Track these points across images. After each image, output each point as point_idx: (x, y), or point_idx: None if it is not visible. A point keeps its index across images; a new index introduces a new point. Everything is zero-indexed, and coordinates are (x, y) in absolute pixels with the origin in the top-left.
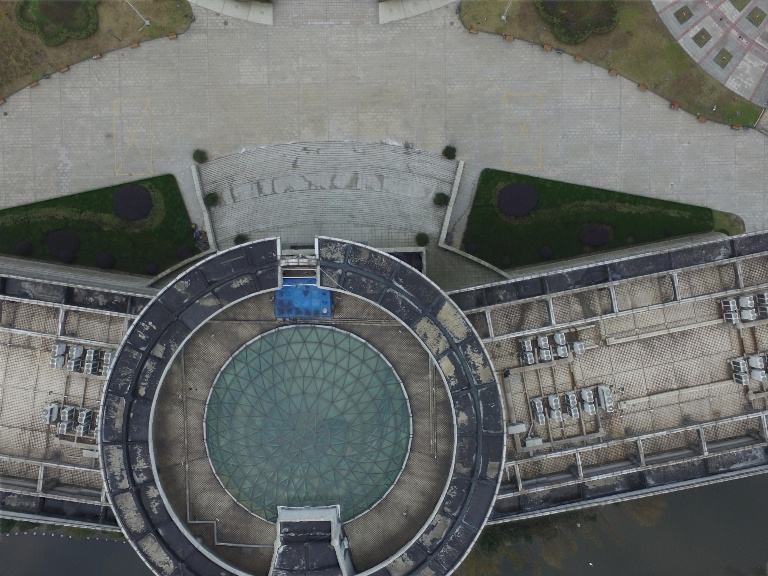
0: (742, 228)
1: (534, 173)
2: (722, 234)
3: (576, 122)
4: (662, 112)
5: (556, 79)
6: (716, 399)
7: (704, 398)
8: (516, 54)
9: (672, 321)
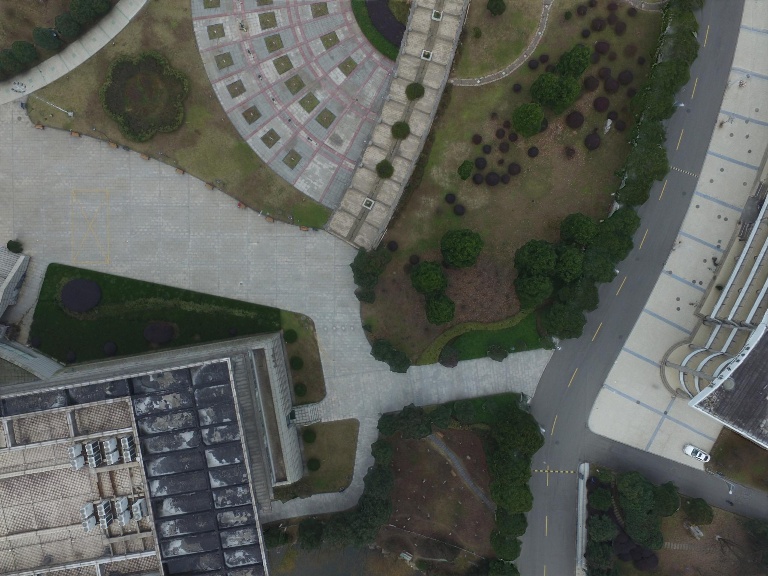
0: (312, 329)
1: (102, 268)
2: (267, 339)
3: (144, 219)
4: (231, 211)
5: (124, 176)
6: (78, 541)
7: (65, 539)
8: (84, 150)
9: (32, 462)
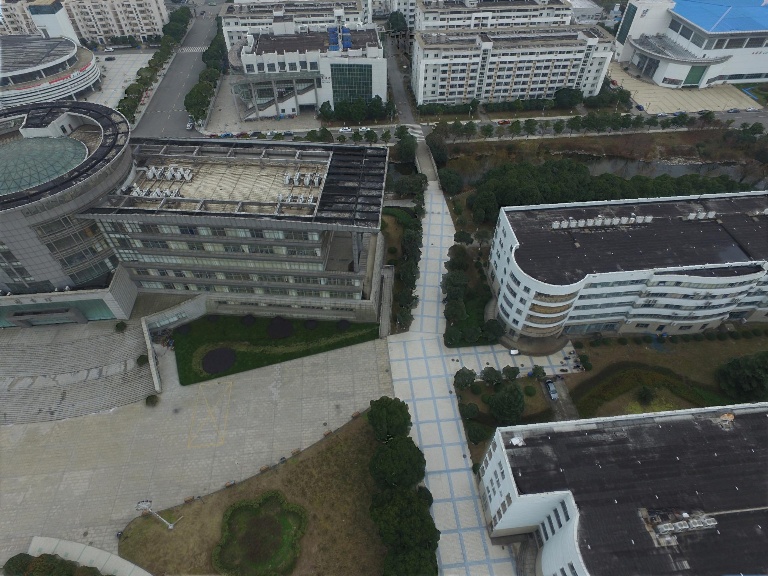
0: None
1: None
2: None
3: None
4: None
5: None
6: None
7: None
8: None
9: None
